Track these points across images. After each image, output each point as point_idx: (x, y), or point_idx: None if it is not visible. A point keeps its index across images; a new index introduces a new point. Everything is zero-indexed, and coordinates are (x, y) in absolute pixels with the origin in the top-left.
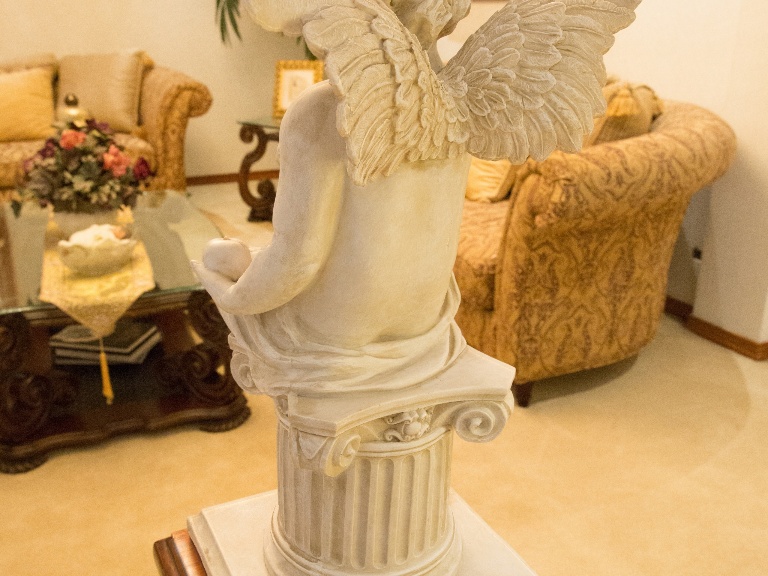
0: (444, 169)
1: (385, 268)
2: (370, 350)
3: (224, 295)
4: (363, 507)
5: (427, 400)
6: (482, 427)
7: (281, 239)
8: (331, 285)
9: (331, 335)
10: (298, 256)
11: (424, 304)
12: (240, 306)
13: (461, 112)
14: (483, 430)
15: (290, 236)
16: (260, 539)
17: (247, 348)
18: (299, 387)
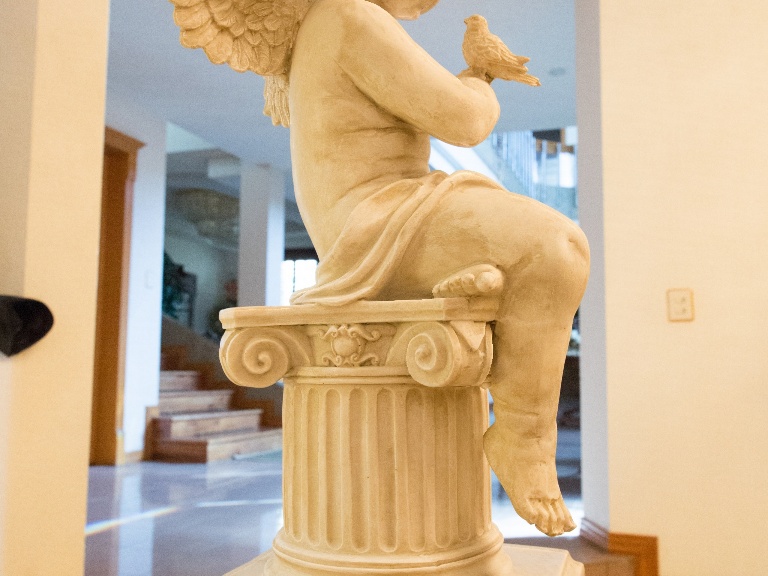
0: None
1: None
2: None
3: None
4: None
5: None
6: None
7: None
8: None
9: None
10: None
11: None
12: None
13: None
14: None
15: None
16: None
17: None
18: None
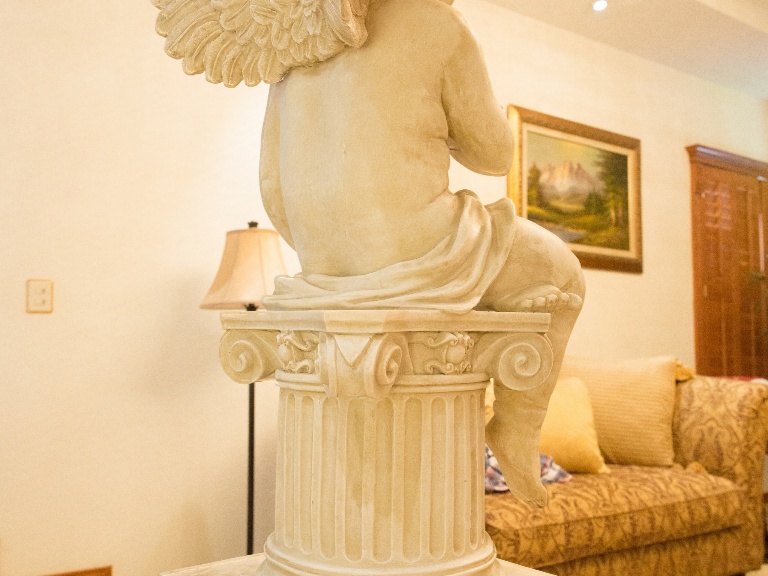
0: (335, 70)
1: (288, 176)
2: (311, 277)
3: None
4: None
5: (291, 320)
6: None
7: None
8: None
9: None
10: None
11: (343, 227)
12: None
13: None
14: None
15: None
16: None
17: None
18: None
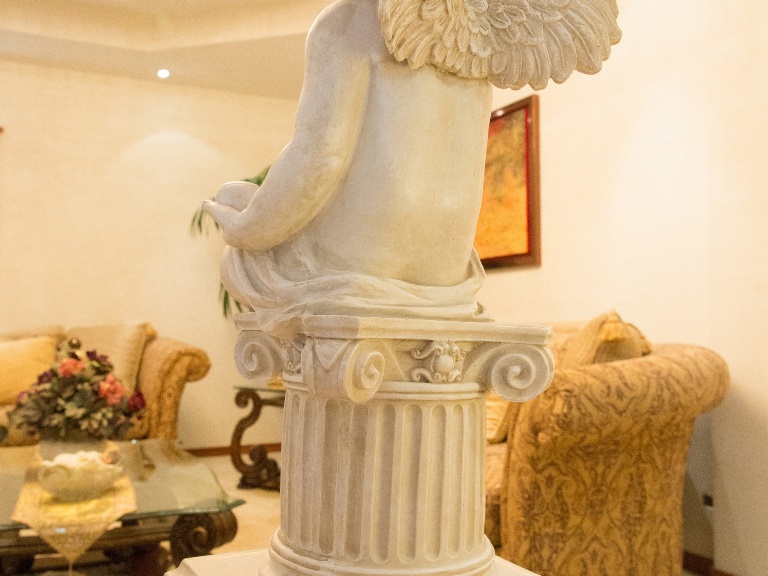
0: (467, 91)
1: (411, 173)
2: (393, 282)
3: (238, 217)
4: (386, 473)
5: (459, 330)
6: (521, 378)
7: (304, 130)
8: (353, 195)
9: (351, 259)
10: (321, 144)
11: (450, 240)
12: (255, 219)
13: (482, 26)
14: (523, 381)
15: (314, 124)
16: (254, 575)
17: (257, 295)
18: (316, 301)
